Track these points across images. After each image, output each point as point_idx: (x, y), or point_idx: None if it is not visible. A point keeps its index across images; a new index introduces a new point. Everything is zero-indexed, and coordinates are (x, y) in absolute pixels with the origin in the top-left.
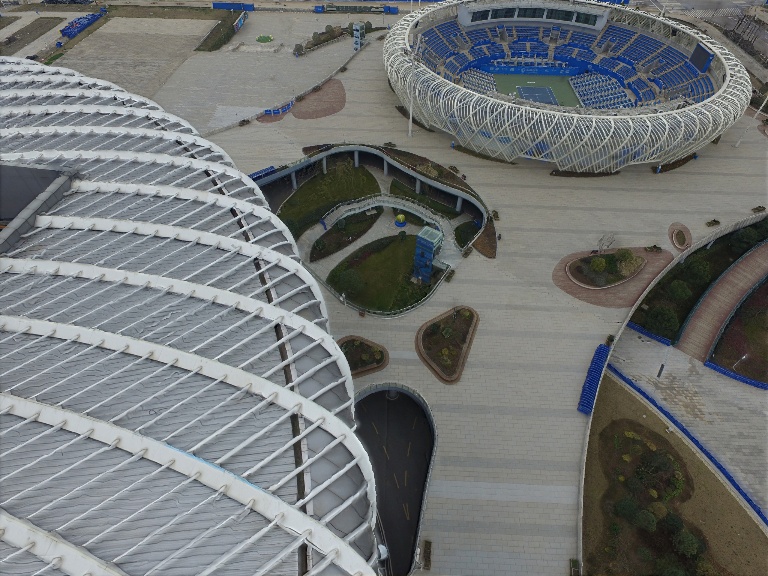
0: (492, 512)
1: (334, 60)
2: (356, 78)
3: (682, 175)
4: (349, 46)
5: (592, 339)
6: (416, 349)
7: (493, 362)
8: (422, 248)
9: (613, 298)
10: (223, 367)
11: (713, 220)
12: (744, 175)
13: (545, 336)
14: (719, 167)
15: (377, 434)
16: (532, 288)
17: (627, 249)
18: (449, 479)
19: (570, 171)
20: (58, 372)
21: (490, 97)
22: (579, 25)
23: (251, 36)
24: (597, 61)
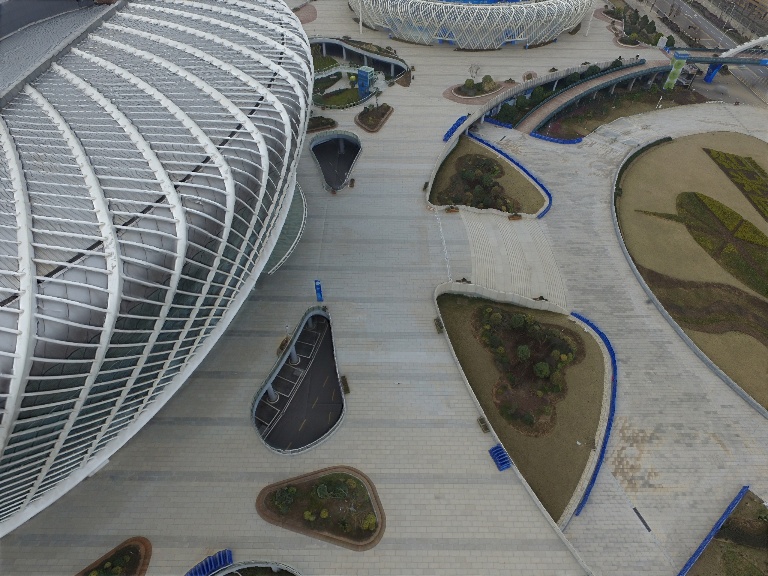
0: (388, 172)
1: None
2: (325, 4)
3: (543, 50)
4: None
5: None
6: (354, 121)
7: (399, 125)
8: (362, 79)
9: (478, 101)
10: (253, 5)
11: (552, 68)
12: (585, 49)
13: (432, 116)
14: (570, 46)
15: (332, 166)
16: (429, 98)
17: (488, 75)
18: (367, 163)
19: (468, 49)
20: (195, 0)
21: None
22: None
23: None
24: None
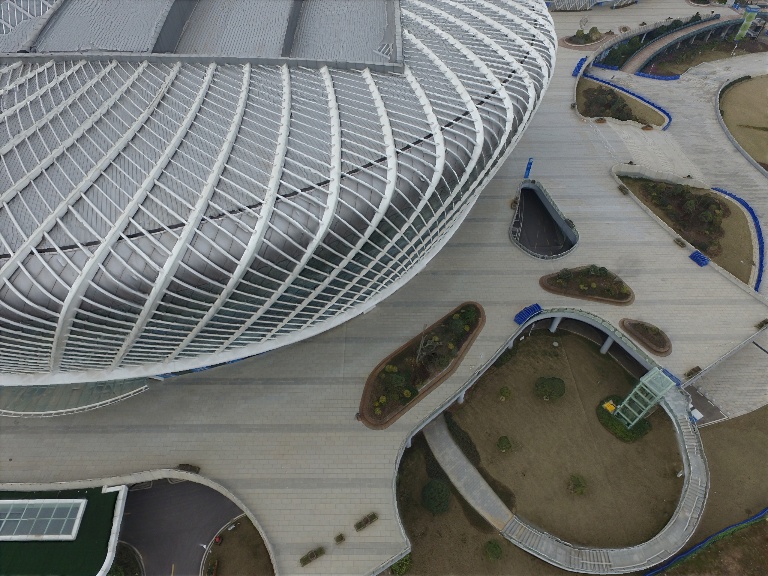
0: None
1: None
2: None
3: (628, 9)
4: None
5: (578, 59)
6: None
7: None
8: None
9: (588, 48)
10: None
11: (643, 22)
12: (664, 8)
13: None
14: (650, 6)
15: None
16: None
17: None
18: None
19: (563, 10)
20: None
21: None
22: None
23: None
24: None
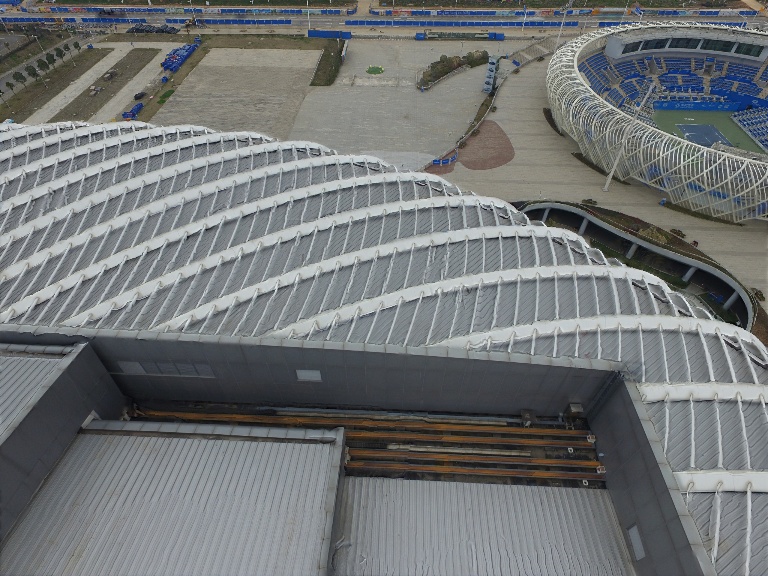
0: None
1: (464, 95)
2: (511, 119)
3: None
4: (473, 78)
5: None
6: None
7: None
8: None
9: None
10: None
11: None
12: None
13: None
14: None
15: None
16: None
17: None
18: None
19: None
20: None
21: (722, 151)
22: (738, 56)
23: (359, 67)
24: (763, 96)
